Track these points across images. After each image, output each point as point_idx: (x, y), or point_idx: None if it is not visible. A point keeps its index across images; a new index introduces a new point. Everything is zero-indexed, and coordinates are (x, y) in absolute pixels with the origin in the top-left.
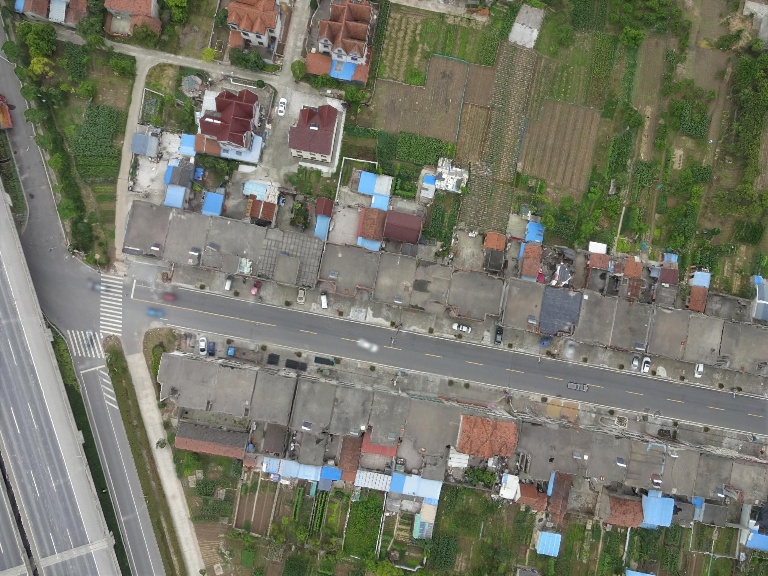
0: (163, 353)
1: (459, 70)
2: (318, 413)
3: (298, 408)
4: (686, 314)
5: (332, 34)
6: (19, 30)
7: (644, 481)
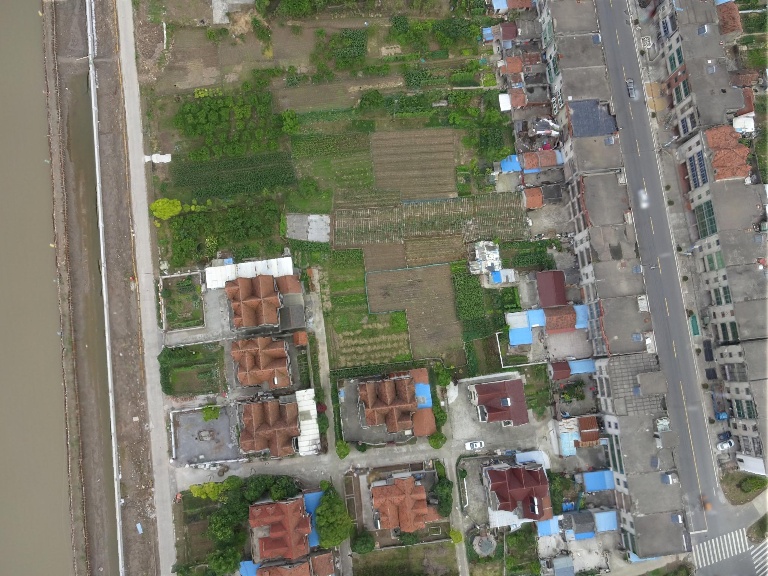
0: None
1: (376, 281)
2: (764, 312)
3: (767, 332)
4: (551, 5)
5: (402, 416)
6: None
7: (709, 7)
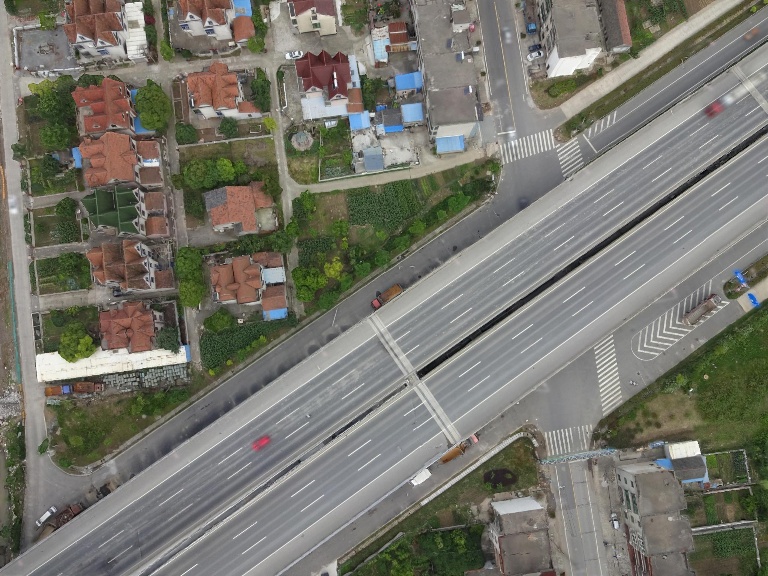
0: (559, 58)
1: None
2: None
3: None
4: None
5: None
6: (307, 293)
7: None
